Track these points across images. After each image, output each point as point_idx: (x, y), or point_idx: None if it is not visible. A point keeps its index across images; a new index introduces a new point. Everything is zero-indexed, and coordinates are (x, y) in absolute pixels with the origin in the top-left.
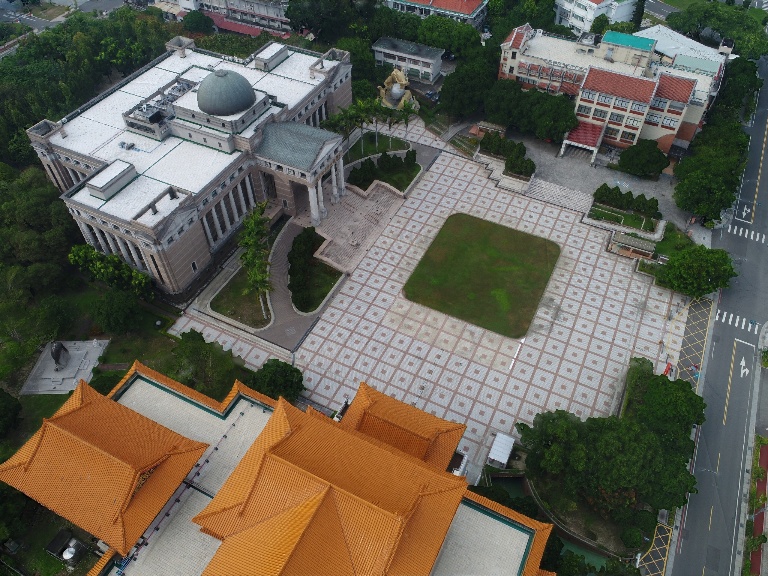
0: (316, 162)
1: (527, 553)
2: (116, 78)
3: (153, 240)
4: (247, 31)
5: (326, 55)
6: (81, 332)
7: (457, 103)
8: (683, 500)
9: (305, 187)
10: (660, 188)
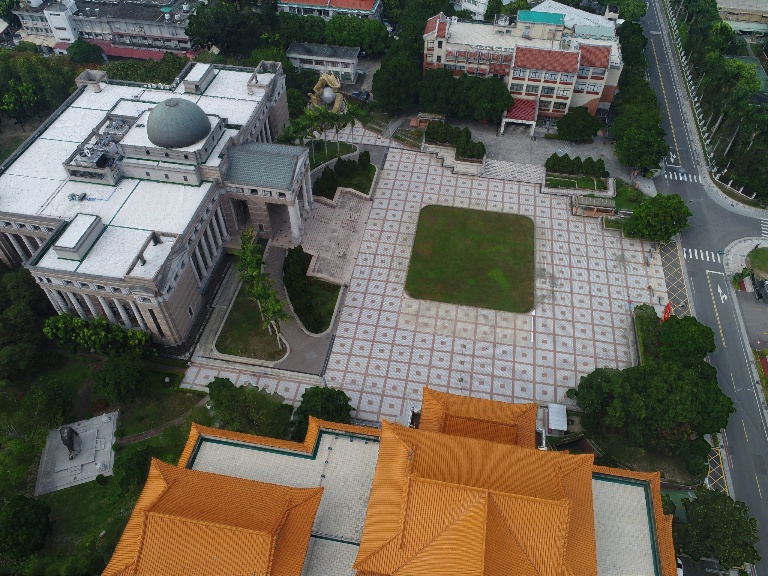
0: (293, 179)
1: (649, 504)
2: (5, 126)
3: (154, 292)
4: (142, 55)
5: (258, 69)
6: (81, 410)
7: (394, 98)
8: (725, 421)
9: (272, 207)
10: (597, 149)
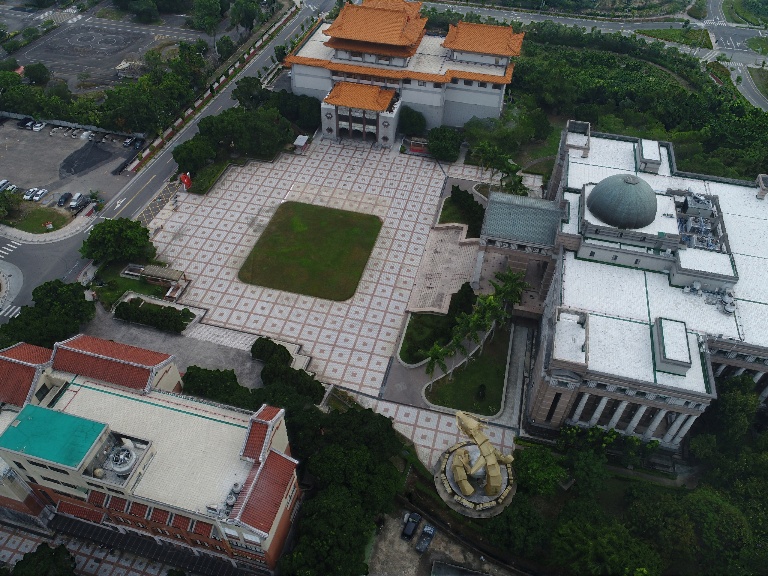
0: None
1: None
2: None
3: None
4: None
5: None
6: None
7: None
8: None
9: None
10: None
